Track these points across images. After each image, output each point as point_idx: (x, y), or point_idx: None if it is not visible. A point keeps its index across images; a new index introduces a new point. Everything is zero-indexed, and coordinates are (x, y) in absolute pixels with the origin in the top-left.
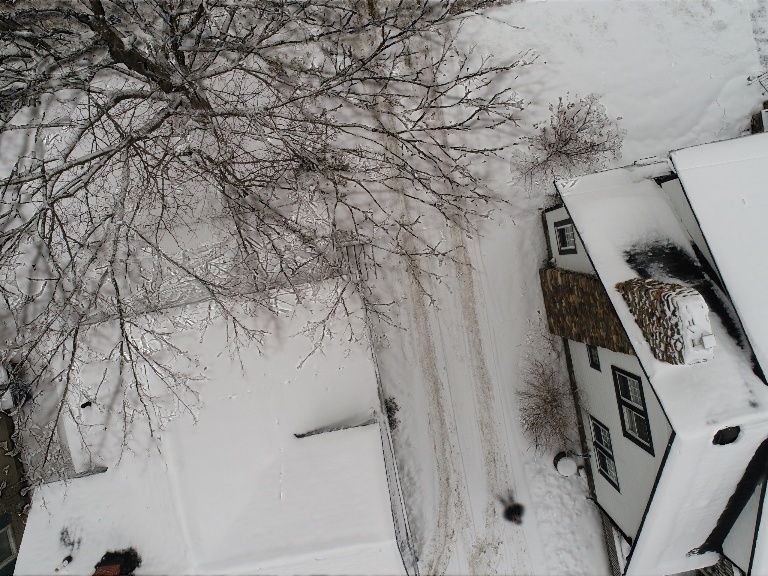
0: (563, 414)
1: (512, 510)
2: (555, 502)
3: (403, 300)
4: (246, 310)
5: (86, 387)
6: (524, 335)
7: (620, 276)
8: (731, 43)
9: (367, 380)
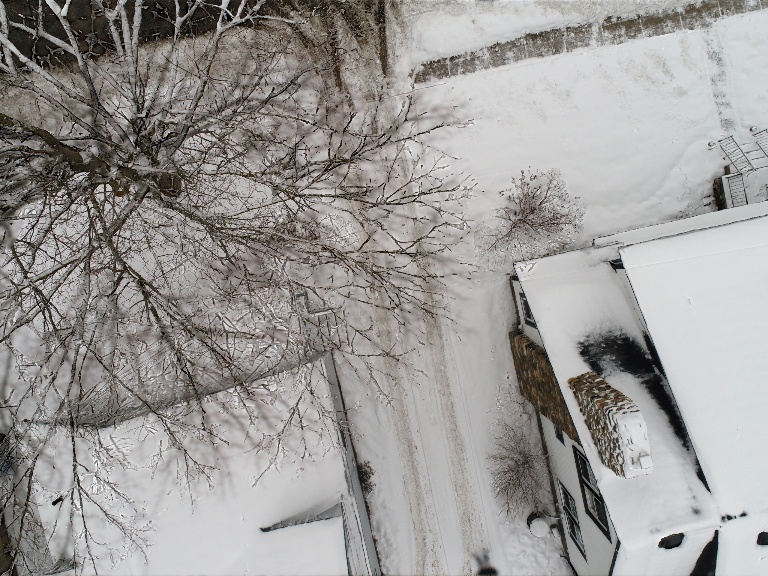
0: (535, 475)
1: (488, 568)
2: (529, 561)
3: (376, 365)
4: (199, 437)
5: (41, 529)
6: (495, 398)
7: (573, 370)
8: (692, 108)
9: (333, 465)
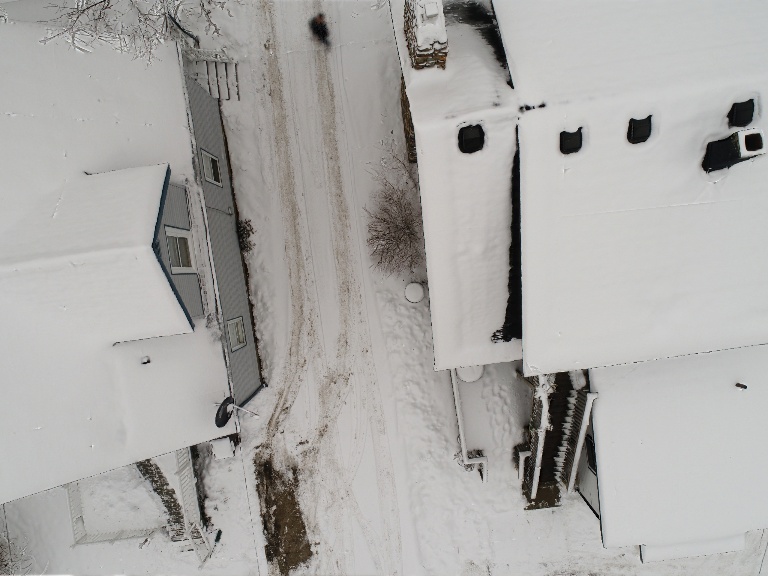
0: (416, 243)
1: (364, 342)
2: (404, 332)
3: (265, 124)
4: None
5: None
6: None
7: None
8: None
9: (180, 146)
